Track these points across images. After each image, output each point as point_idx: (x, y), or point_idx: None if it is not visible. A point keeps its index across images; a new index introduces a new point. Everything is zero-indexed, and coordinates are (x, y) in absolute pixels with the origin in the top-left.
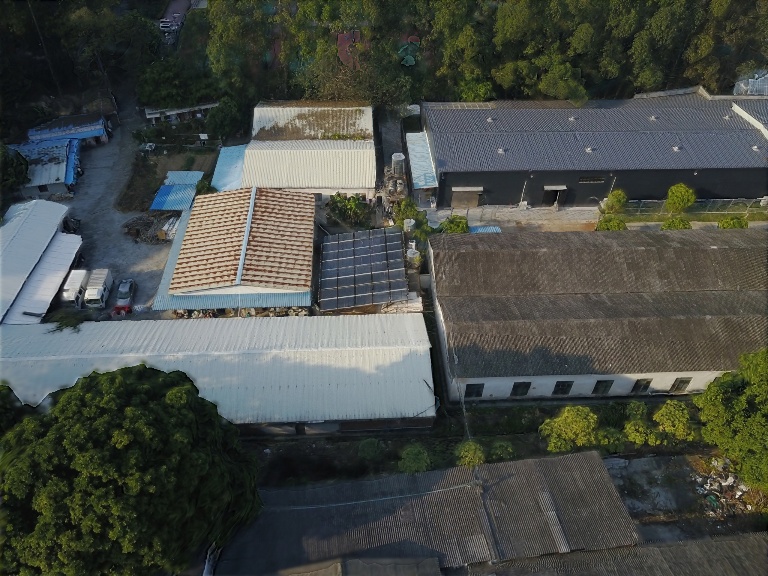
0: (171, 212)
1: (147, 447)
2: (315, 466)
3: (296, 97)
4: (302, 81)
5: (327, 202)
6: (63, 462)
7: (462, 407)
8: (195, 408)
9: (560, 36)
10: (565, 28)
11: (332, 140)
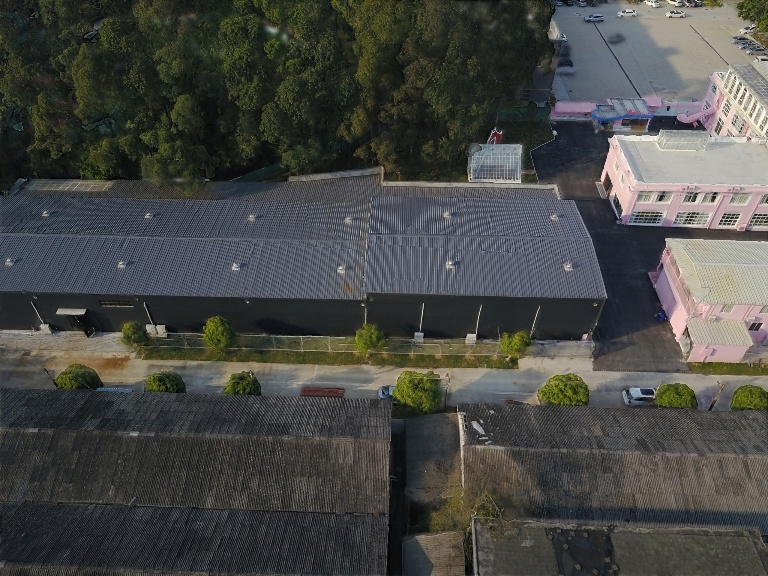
0: None
1: None
2: None
3: None
4: None
5: None
6: None
7: None
8: None
9: (165, 108)
10: (164, 99)
11: None
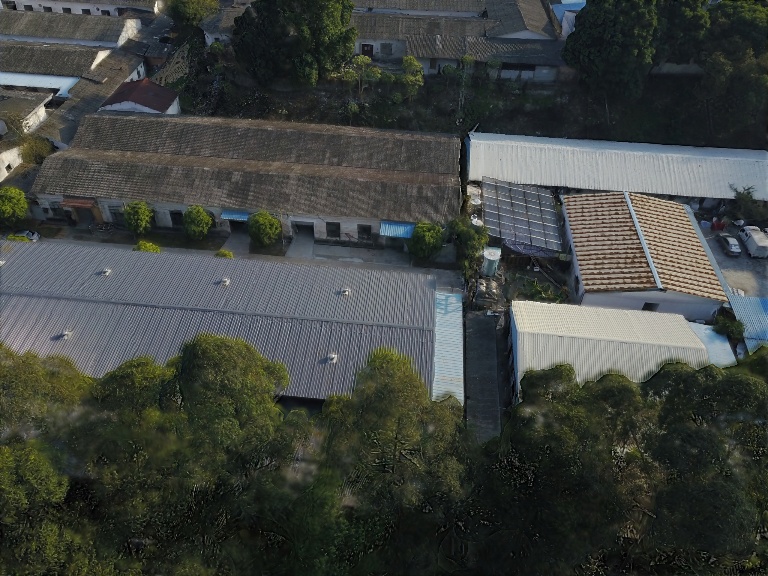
0: None
1: None
2: (537, 115)
3: None
4: None
5: None
6: None
7: None
8: None
9: None
10: None
11: None
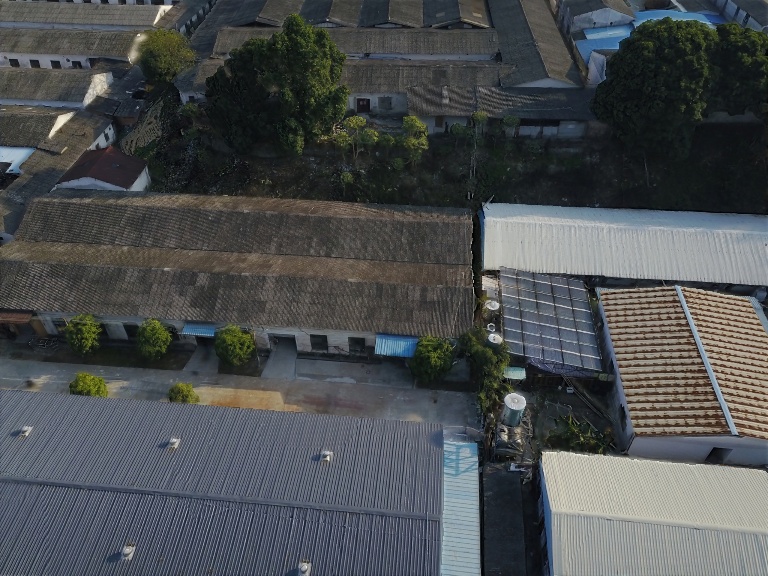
0: None
1: None
2: (563, 178)
3: None
4: None
5: None
6: None
7: None
8: None
9: None
10: None
11: None
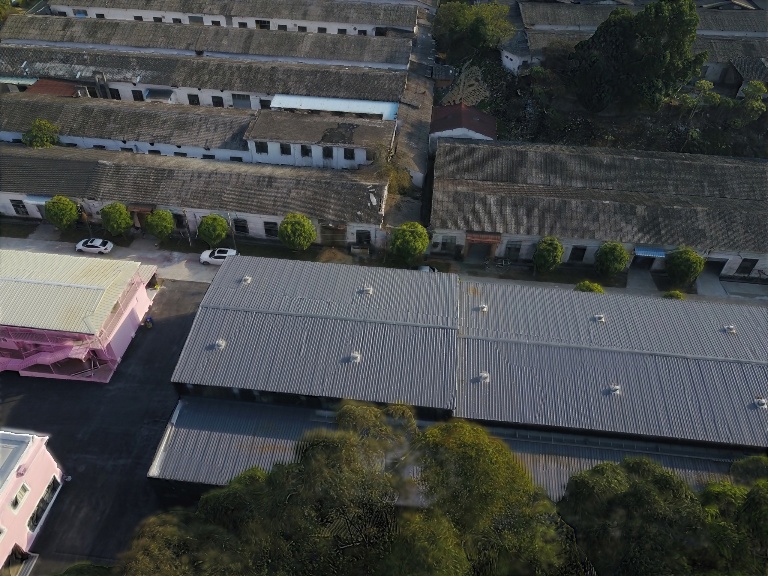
0: None
1: None
2: None
3: None
4: None
5: None
6: None
7: None
8: None
9: None
10: None
11: None
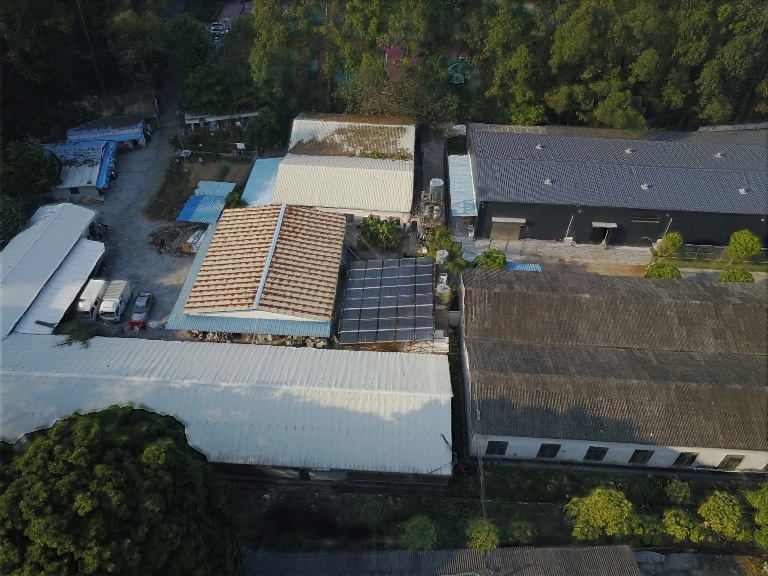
0: (198, 224)
1: (112, 515)
2: (314, 522)
3: (338, 110)
4: (344, 95)
5: (359, 224)
6: (17, 527)
7: (479, 475)
8: (175, 468)
9: (622, 61)
10: (628, 53)
11: (370, 158)
